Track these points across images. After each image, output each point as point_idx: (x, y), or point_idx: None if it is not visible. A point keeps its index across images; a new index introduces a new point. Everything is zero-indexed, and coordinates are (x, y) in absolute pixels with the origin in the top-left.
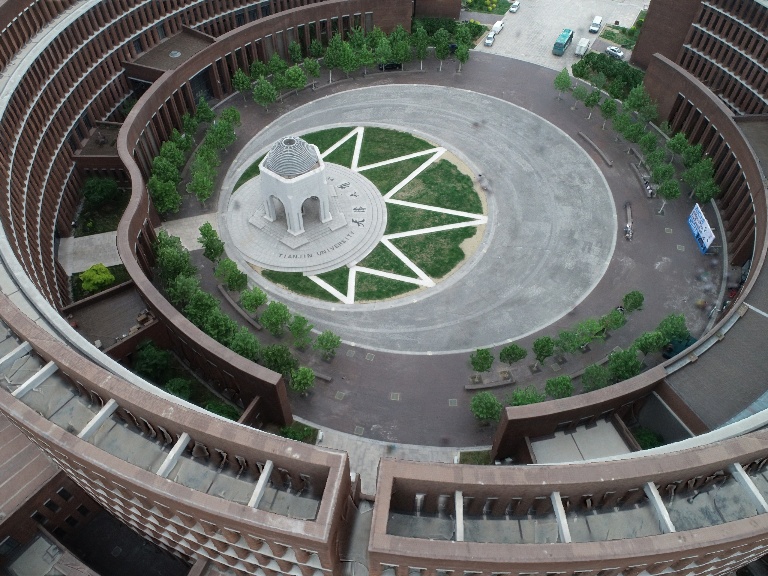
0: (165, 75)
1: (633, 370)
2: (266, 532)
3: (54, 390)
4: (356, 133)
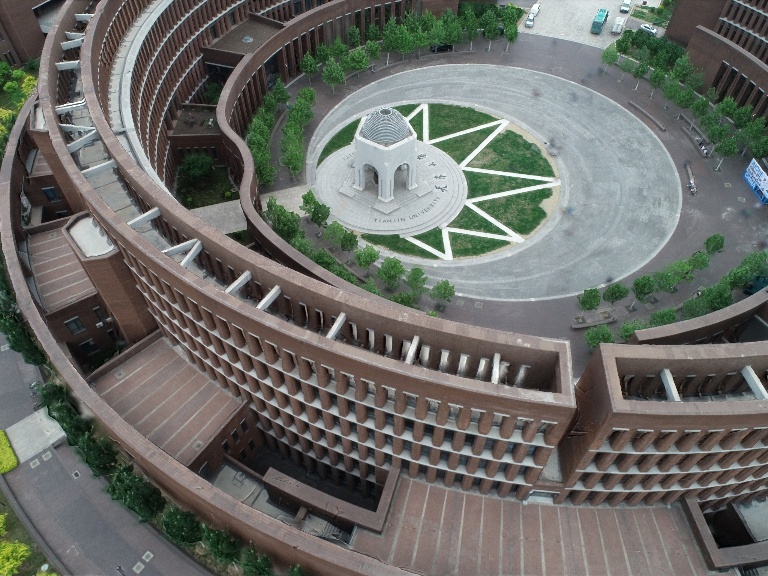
0: (246, 58)
1: (727, 302)
2: (519, 405)
3: (275, 313)
4: (421, 109)
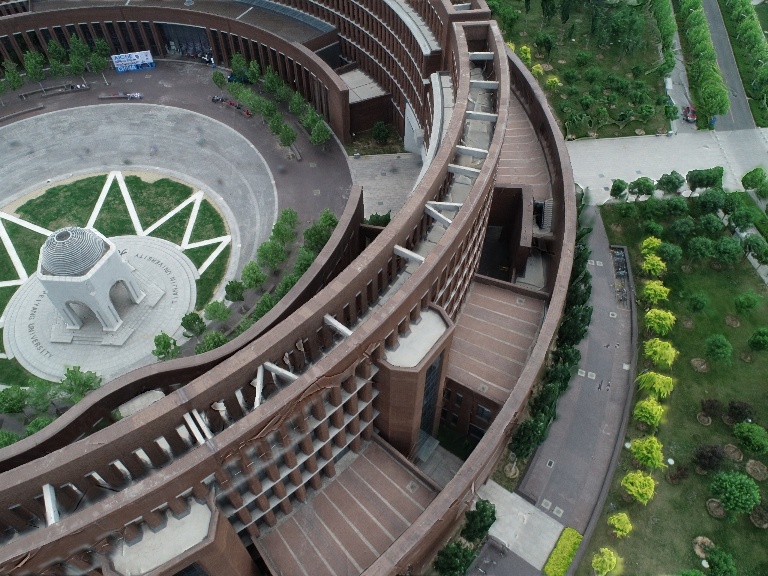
0: None
1: None
2: None
3: None
4: None
